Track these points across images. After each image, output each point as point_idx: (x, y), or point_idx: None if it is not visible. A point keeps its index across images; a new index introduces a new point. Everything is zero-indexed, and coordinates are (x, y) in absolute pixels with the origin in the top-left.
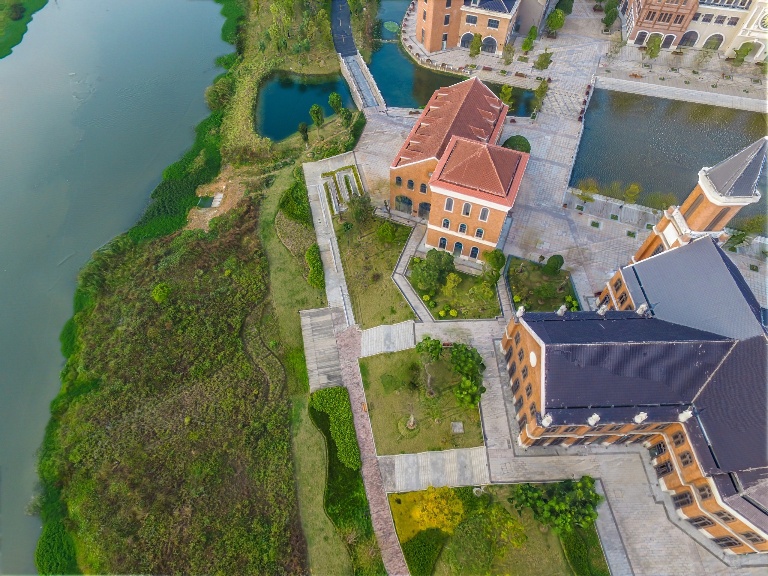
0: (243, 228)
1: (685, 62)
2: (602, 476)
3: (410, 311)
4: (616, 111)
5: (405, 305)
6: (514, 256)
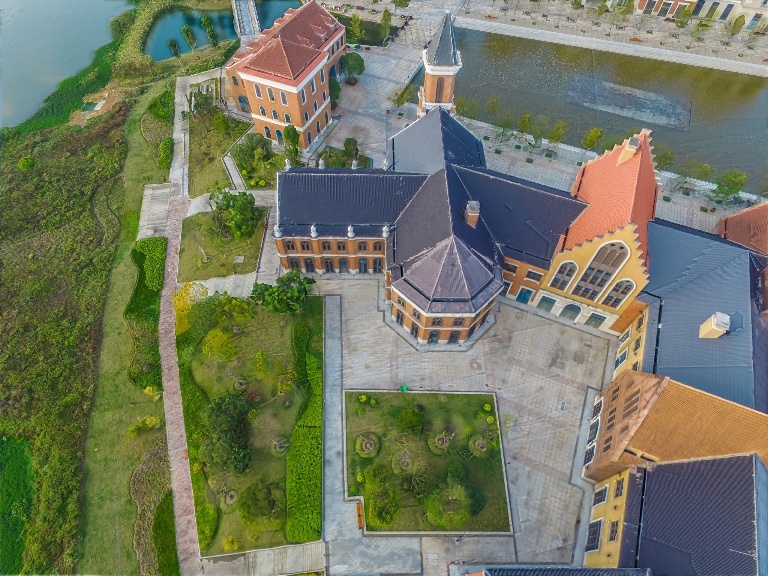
0: (111, 123)
1: (539, 7)
2: (343, 293)
3: (229, 182)
4: (464, 45)
5: (226, 178)
6: (329, 146)
